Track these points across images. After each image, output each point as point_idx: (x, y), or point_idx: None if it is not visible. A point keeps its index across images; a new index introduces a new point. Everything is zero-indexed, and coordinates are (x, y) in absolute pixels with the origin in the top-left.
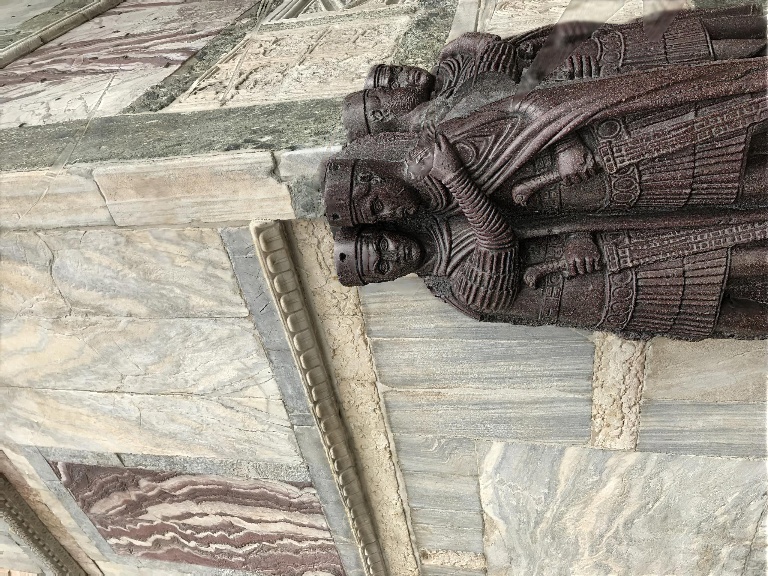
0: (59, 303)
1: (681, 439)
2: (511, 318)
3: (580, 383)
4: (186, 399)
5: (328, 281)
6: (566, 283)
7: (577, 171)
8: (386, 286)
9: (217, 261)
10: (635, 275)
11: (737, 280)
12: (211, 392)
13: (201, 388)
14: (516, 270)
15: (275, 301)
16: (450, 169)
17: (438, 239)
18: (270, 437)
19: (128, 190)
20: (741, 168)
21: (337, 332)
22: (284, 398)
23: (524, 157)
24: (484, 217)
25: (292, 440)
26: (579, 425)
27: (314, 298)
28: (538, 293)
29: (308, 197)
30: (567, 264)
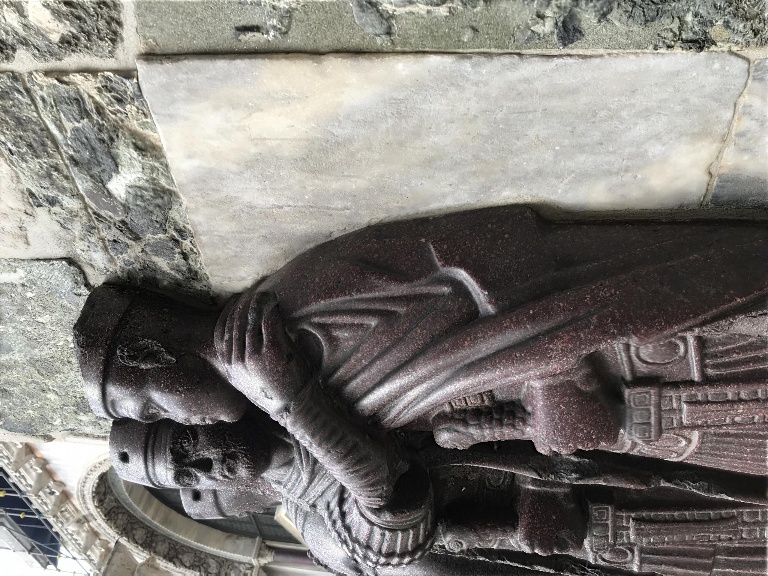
0: None
1: None
2: None
3: None
4: None
5: None
6: None
7: None
8: None
9: None
10: None
11: None
12: None
13: None
14: None
15: None
16: None
17: None
18: None
19: None
20: None
21: None
22: None
23: None
24: None
25: None
26: None
27: None
28: None
29: None
30: None
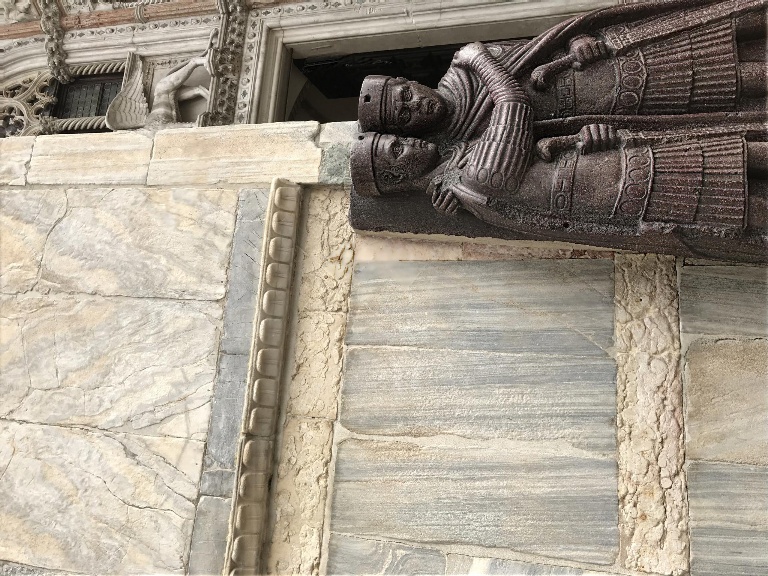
0: (31, 273)
1: (756, 554)
2: (520, 213)
3: (600, 431)
4: (84, 436)
5: (324, 264)
6: (580, 158)
7: (589, 43)
8: (384, 272)
9: (222, 226)
10: (651, 149)
11: (762, 190)
12: (121, 425)
13: (113, 416)
14: (530, 133)
15: (262, 265)
16: (479, 49)
17: (455, 149)
18: (158, 522)
19: (178, 149)
20: (733, 50)
21: (311, 337)
22: (209, 438)
23: (543, 40)
24: (504, 76)
25: (186, 531)
26: (601, 518)
27: (301, 287)
28: (551, 167)
29: (337, 163)
30: (581, 134)
